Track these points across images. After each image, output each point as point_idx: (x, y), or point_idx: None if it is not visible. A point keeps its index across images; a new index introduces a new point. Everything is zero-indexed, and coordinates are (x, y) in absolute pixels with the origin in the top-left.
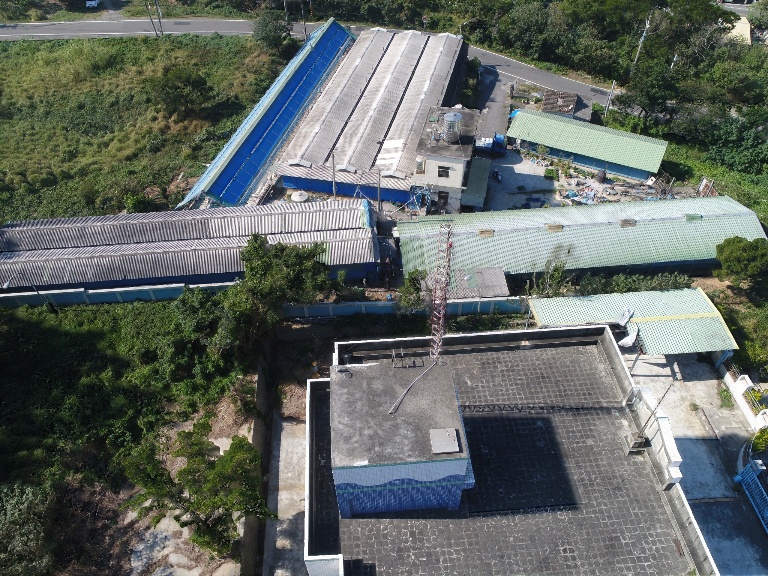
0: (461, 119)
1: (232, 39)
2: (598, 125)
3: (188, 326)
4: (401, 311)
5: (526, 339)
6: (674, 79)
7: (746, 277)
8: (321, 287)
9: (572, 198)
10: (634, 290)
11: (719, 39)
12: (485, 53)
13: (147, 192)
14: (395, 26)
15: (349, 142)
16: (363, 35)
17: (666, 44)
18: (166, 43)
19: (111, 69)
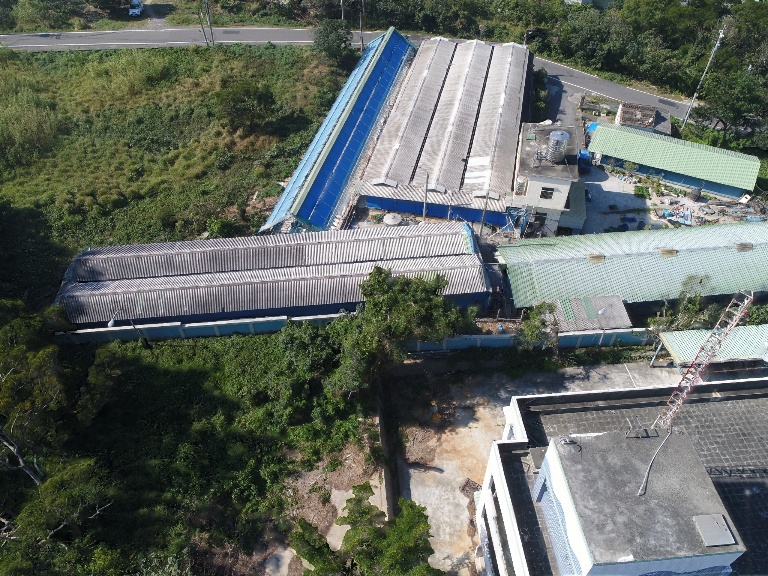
0: (568, 138)
1: (286, 49)
2: (681, 139)
3: (302, 365)
4: (524, 346)
5: (716, 390)
6: (754, 91)
7: None
8: (453, 324)
9: (669, 218)
10: (767, 321)
11: None
12: (546, 63)
13: (225, 214)
14: (450, 35)
15: (433, 159)
16: (425, 45)
17: (733, 53)
18: (219, 53)
19: (166, 81)
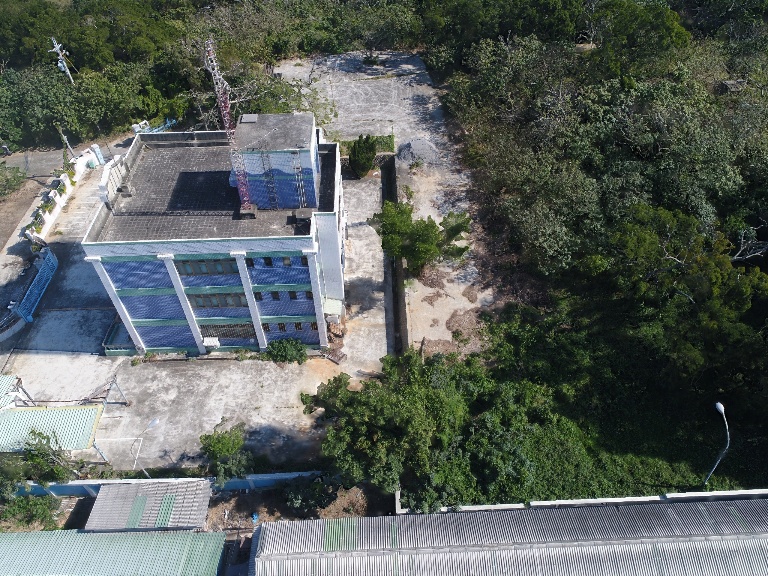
0: None
1: None
2: None
3: (495, 420)
4: None
5: None
6: None
7: None
8: None
9: None
10: None
11: None
12: None
13: None
14: None
15: None
16: None
17: None
18: None
19: None
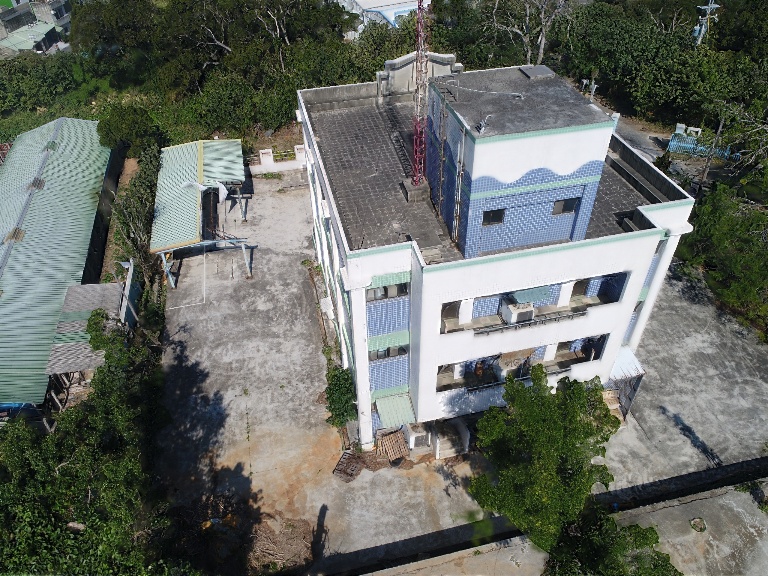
0: None
1: None
2: None
3: None
4: None
5: None
6: None
7: None
8: None
9: None
10: (150, 187)
11: None
12: None
13: None
14: None
15: None
16: None
17: None
18: None
19: None
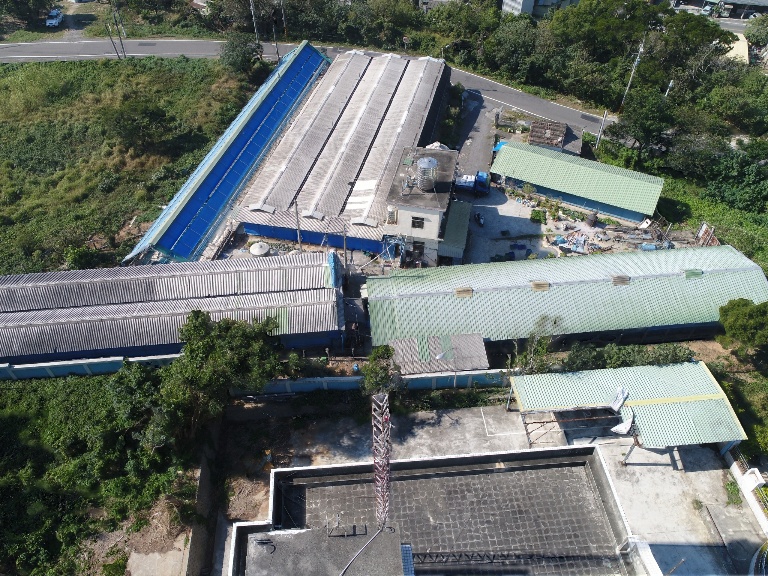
0: (436, 165)
1: (199, 62)
2: (589, 160)
3: (121, 413)
4: None
5: (501, 460)
6: (670, 108)
7: (753, 347)
8: (270, 373)
9: (560, 245)
10: (628, 363)
11: (717, 62)
12: (469, 76)
13: (93, 241)
14: (374, 47)
15: (317, 183)
16: (338, 59)
17: (661, 67)
18: (128, 67)
19: (66, 96)
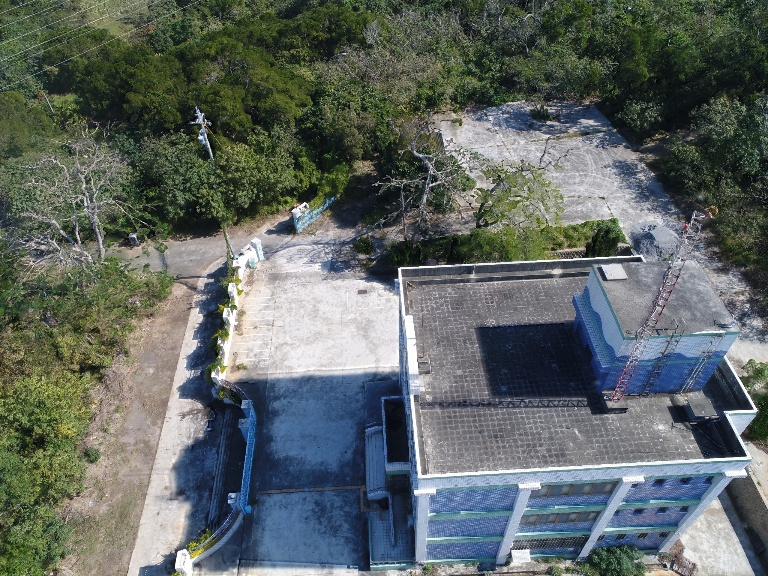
0: None
1: None
2: None
3: None
4: None
5: None
6: None
7: None
8: None
9: None
10: None
11: None
12: None
13: None
14: None
15: None
16: None
17: None
18: None
19: None
